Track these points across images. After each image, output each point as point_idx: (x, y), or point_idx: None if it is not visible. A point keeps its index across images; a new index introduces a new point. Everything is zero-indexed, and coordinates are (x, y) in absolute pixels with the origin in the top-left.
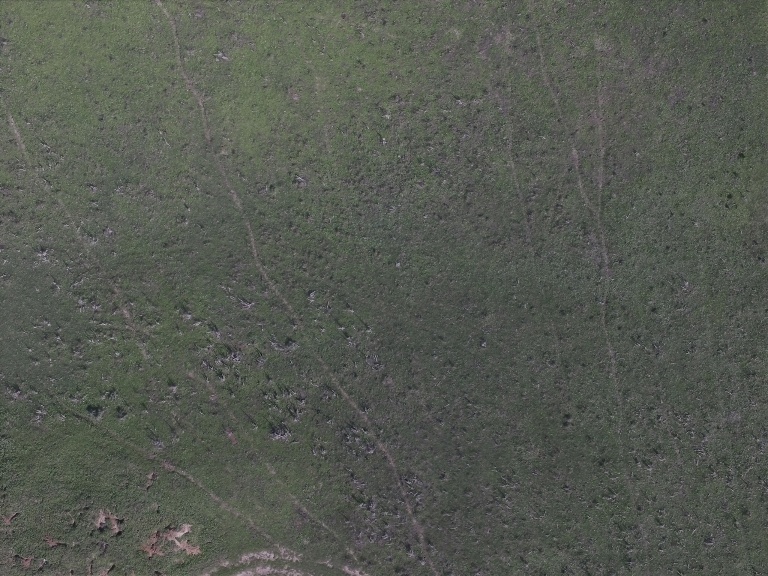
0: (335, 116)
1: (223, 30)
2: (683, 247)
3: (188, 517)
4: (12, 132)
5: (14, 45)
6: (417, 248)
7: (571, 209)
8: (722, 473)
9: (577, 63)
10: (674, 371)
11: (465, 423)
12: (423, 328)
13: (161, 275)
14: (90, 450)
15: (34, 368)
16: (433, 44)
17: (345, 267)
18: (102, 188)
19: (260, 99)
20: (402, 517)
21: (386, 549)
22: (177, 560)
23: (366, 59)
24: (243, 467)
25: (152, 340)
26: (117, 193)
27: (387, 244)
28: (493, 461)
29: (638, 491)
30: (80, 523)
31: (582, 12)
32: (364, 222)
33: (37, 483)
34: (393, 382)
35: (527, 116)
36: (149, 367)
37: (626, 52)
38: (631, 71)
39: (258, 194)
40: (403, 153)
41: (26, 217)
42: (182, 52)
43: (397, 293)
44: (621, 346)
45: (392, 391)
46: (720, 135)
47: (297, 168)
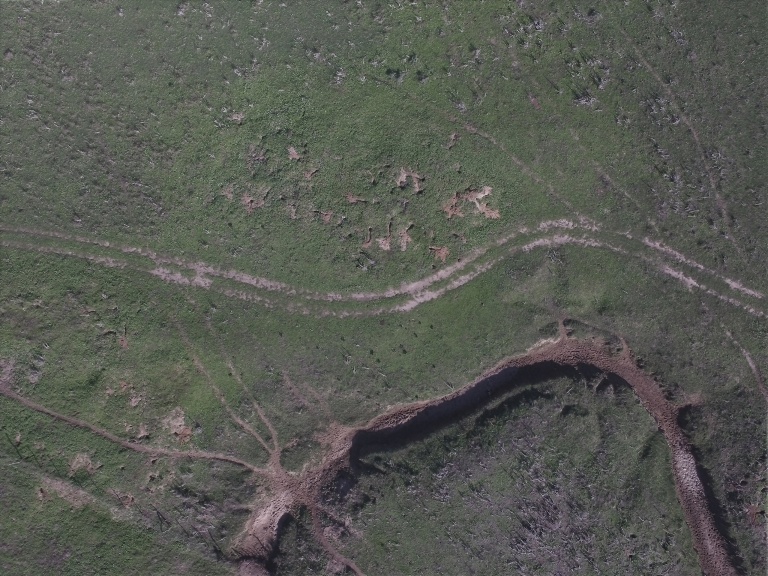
0: None
1: None
2: None
3: (489, 179)
4: None
5: None
6: None
7: None
8: None
9: None
10: None
11: None
12: (727, 6)
13: None
14: (390, 111)
15: (333, 33)
16: None
17: None
18: None
19: None
20: (705, 191)
21: (688, 221)
22: (475, 223)
23: None
24: (546, 132)
25: (453, 6)
26: None
27: None
28: None
29: None
30: (381, 180)
31: None
32: None
33: (337, 141)
34: (697, 57)
35: None
36: (450, 33)
37: None
38: None
39: None
40: None
41: None
42: None
43: None
44: None
45: (696, 66)
46: None
47: None
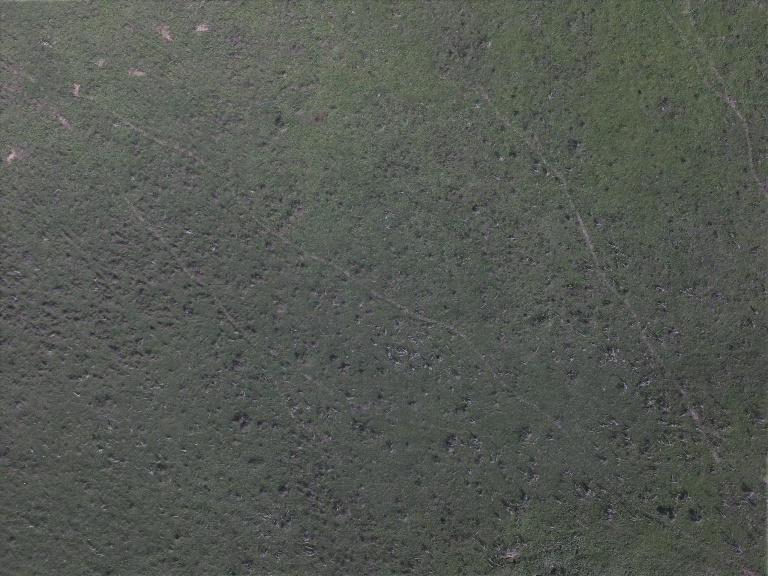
0: None
1: None
2: None
3: None
4: (581, 232)
5: (585, 146)
6: None
7: None
8: None
9: None
10: None
11: None
12: None
13: (728, 378)
14: (664, 552)
15: (601, 466)
16: None
17: None
18: (669, 289)
19: None
20: None
21: None
22: None
23: None
24: None
25: (723, 443)
26: (683, 294)
27: None
28: None
29: None
30: None
31: None
32: None
33: None
34: None
35: None
36: (721, 470)
37: None
38: None
39: None
40: None
41: (594, 317)
42: (755, 155)
43: None
44: None
45: None
46: None
47: None
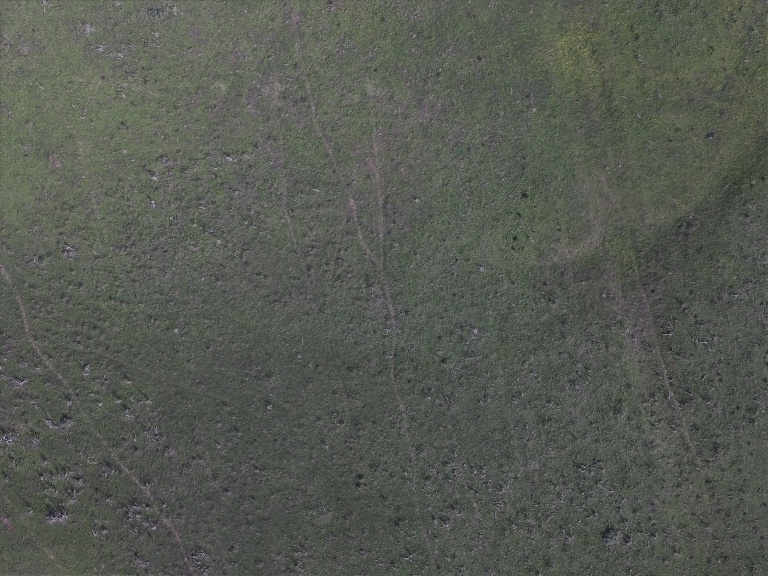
0: (101, 181)
1: None
2: (470, 293)
3: None
4: None
5: None
6: (196, 312)
7: (352, 262)
8: (522, 524)
9: (350, 111)
10: (468, 422)
11: (253, 490)
12: (206, 394)
13: None
14: None
15: None
16: (199, 100)
17: (121, 336)
18: None
19: (21, 168)
20: None
21: None
22: None
23: (130, 120)
24: (20, 553)
25: None
26: None
27: (164, 310)
28: (284, 528)
29: (437, 549)
30: None
31: (352, 58)
32: (139, 288)
33: None
34: (176, 453)
35: (300, 169)
36: None
37: (400, 96)
38: (406, 115)
39: (26, 267)
40: (175, 215)
41: None
42: None
43: (177, 360)
44: (412, 400)
45: (175, 462)
46: (502, 175)
47: (65, 237)
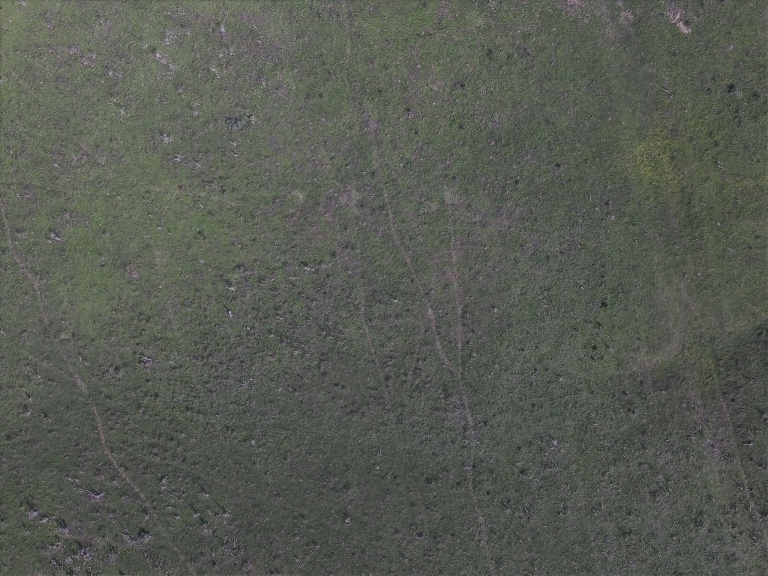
0: (178, 291)
1: (55, 210)
2: (549, 403)
3: None
4: None
5: None
6: (273, 422)
7: (431, 371)
8: None
9: (428, 219)
10: (547, 534)
11: None
12: (283, 507)
13: (5, 470)
14: None
15: None
16: (276, 209)
17: (198, 448)
18: None
19: (98, 279)
20: None
21: None
22: None
23: (207, 230)
24: None
25: None
26: None
27: (241, 420)
28: None
29: None
30: None
31: (430, 165)
32: (216, 399)
33: None
34: (254, 567)
35: (378, 278)
36: None
37: (478, 204)
38: (484, 223)
39: (102, 377)
40: (252, 324)
41: None
42: (13, 235)
43: (254, 471)
44: (491, 511)
45: None
46: (581, 284)
47: (142, 348)
